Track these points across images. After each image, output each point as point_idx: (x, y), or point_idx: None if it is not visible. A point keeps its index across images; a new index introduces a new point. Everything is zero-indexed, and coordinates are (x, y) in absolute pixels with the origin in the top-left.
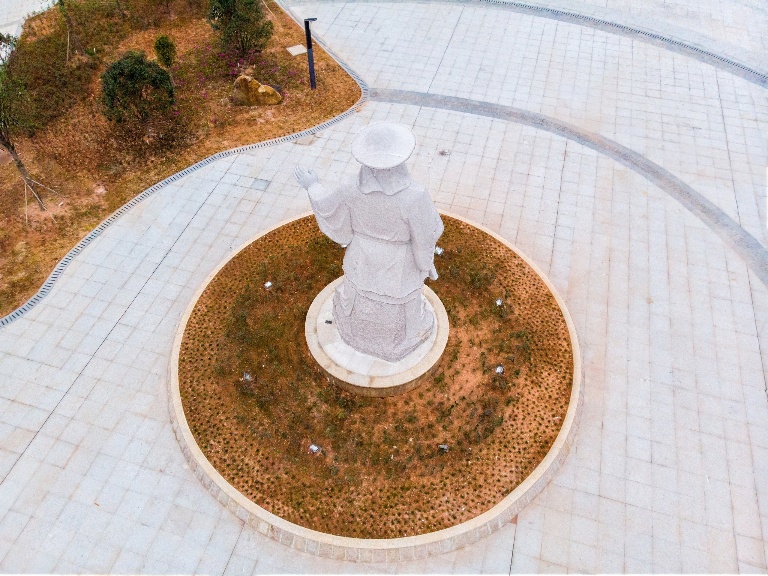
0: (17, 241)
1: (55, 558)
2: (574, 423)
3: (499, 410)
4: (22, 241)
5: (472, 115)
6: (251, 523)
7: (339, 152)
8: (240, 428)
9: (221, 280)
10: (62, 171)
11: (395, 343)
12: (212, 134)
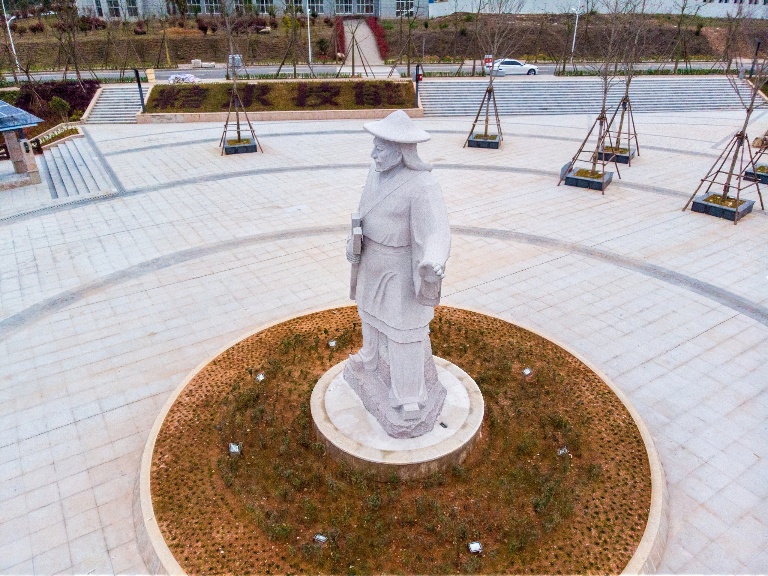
0: None
1: None
2: None
3: None
4: None
5: None
6: None
7: None
8: None
9: None
10: None
11: None
12: None
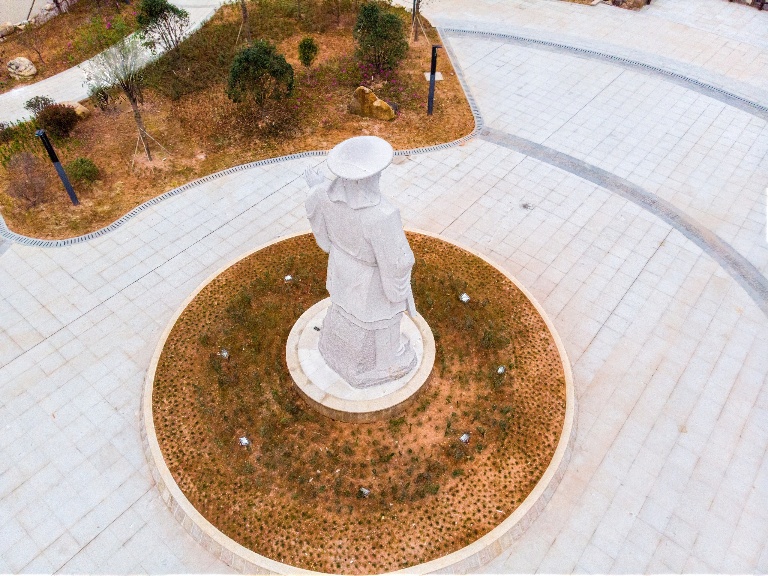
0: (118, 180)
1: (0, 447)
2: (519, 525)
3: (443, 478)
4: (121, 181)
5: (577, 177)
6: (159, 486)
7: (422, 178)
8: (194, 397)
9: (251, 261)
10: (182, 133)
11: (359, 369)
12: (317, 133)
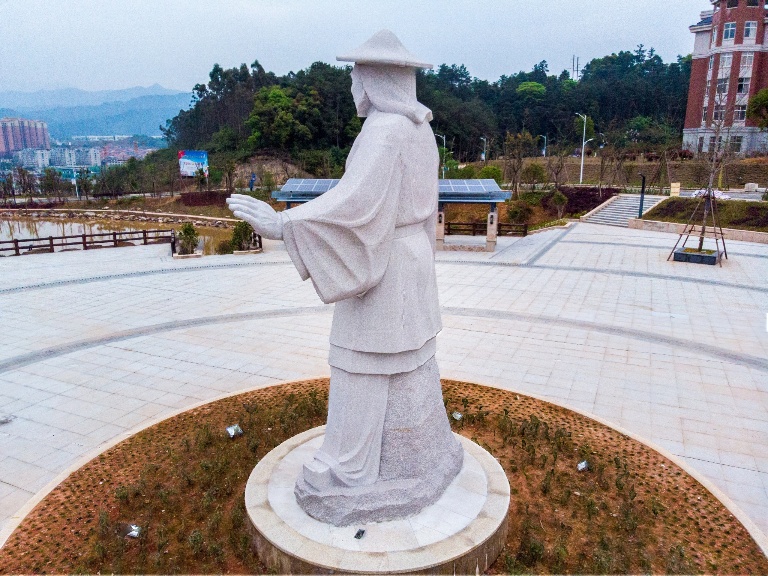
0: None
1: None
2: None
3: None
4: None
5: None
6: None
7: None
8: None
9: None
10: None
11: None
12: None
